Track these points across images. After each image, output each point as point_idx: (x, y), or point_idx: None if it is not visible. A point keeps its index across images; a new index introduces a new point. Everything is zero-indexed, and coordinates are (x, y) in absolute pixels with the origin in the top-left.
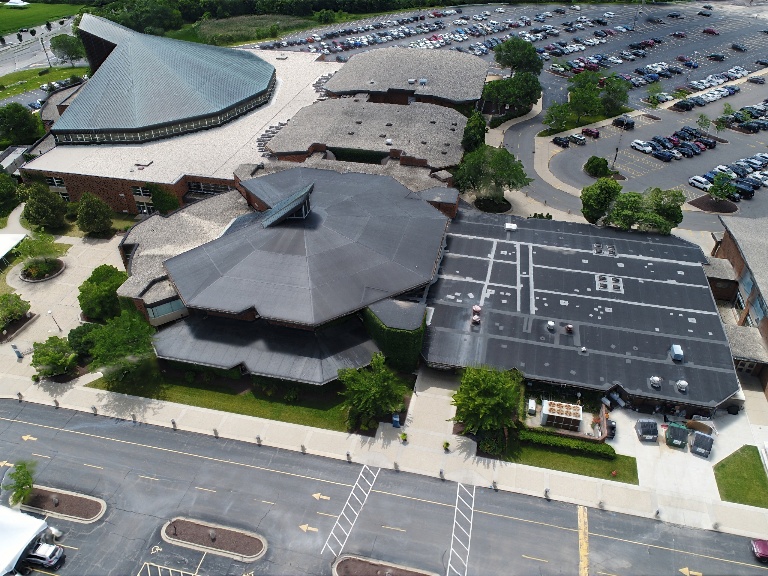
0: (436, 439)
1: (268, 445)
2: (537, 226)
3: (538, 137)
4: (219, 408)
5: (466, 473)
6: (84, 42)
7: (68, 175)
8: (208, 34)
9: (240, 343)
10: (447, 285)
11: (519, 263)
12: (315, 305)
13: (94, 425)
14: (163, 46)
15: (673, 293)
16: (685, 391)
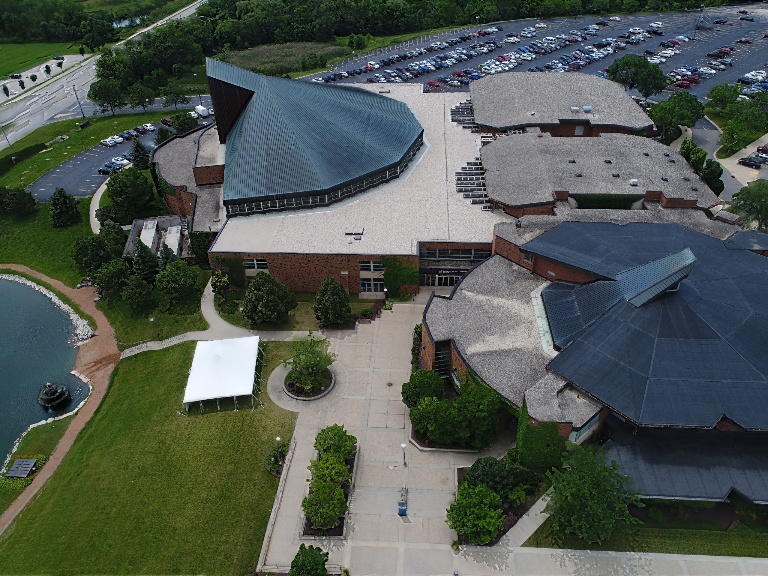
0: None
1: None
2: None
3: (720, 159)
4: (722, 553)
5: None
6: (212, 91)
7: (276, 255)
8: None
9: (707, 462)
10: None
11: None
12: None
13: None
14: (303, 89)
15: None
16: None
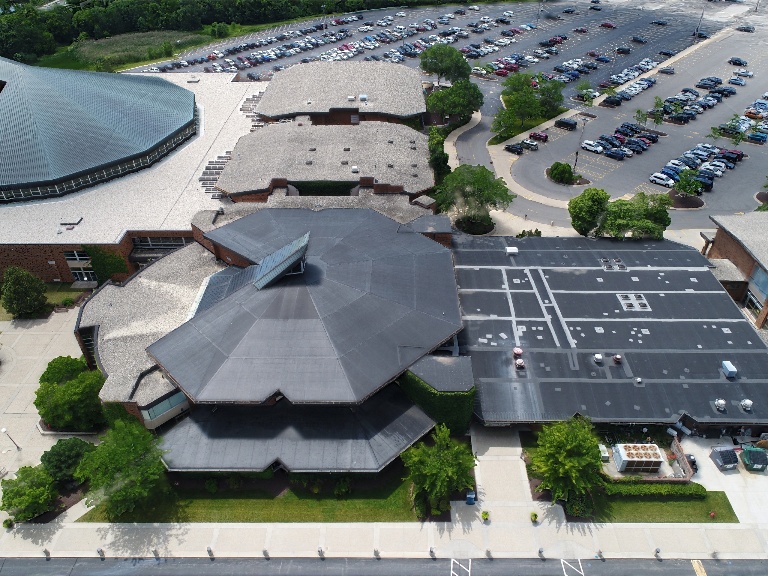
0: (518, 510)
1: (333, 557)
2: (535, 246)
3: (490, 146)
4: (258, 519)
5: (565, 546)
6: None
7: None
8: (91, 57)
9: (267, 435)
10: (474, 327)
11: (537, 291)
12: (350, 378)
13: (106, 573)
14: (63, 79)
15: (697, 303)
16: (750, 410)
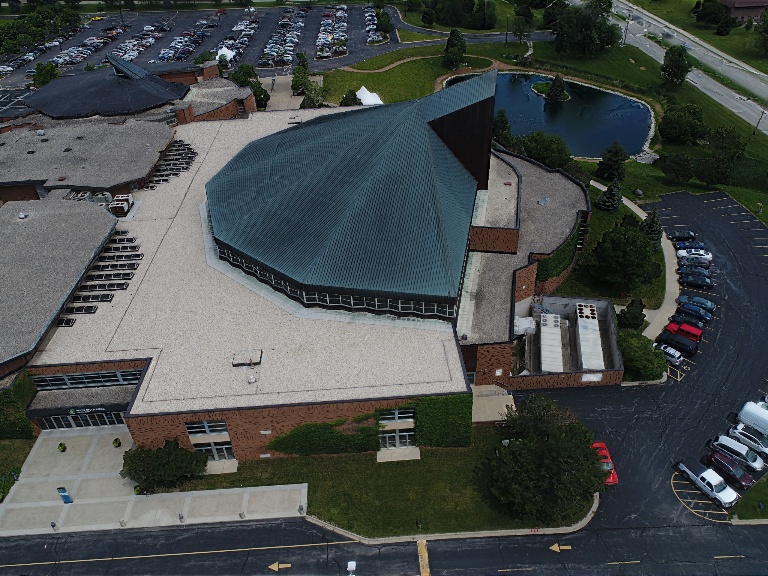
0: None
1: None
2: None
3: None
4: None
5: None
6: None
7: None
8: None
9: None
10: None
11: None
12: None
13: None
14: (363, 121)
15: None
16: None
